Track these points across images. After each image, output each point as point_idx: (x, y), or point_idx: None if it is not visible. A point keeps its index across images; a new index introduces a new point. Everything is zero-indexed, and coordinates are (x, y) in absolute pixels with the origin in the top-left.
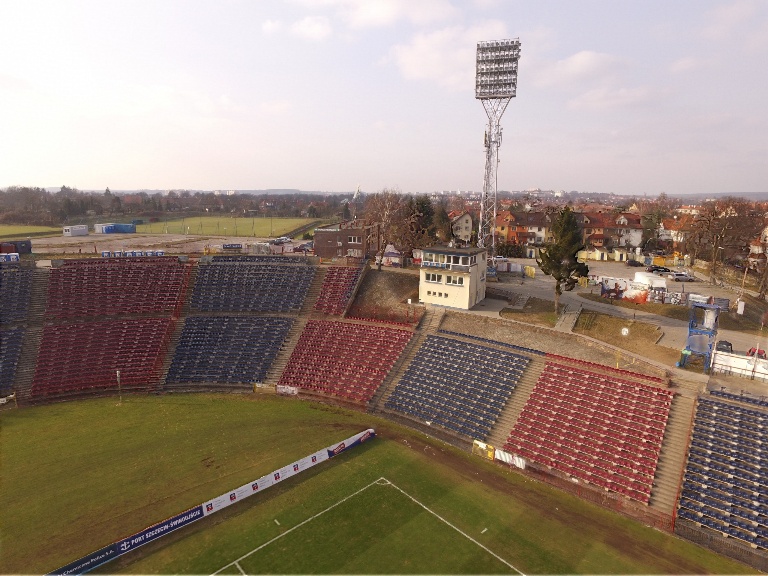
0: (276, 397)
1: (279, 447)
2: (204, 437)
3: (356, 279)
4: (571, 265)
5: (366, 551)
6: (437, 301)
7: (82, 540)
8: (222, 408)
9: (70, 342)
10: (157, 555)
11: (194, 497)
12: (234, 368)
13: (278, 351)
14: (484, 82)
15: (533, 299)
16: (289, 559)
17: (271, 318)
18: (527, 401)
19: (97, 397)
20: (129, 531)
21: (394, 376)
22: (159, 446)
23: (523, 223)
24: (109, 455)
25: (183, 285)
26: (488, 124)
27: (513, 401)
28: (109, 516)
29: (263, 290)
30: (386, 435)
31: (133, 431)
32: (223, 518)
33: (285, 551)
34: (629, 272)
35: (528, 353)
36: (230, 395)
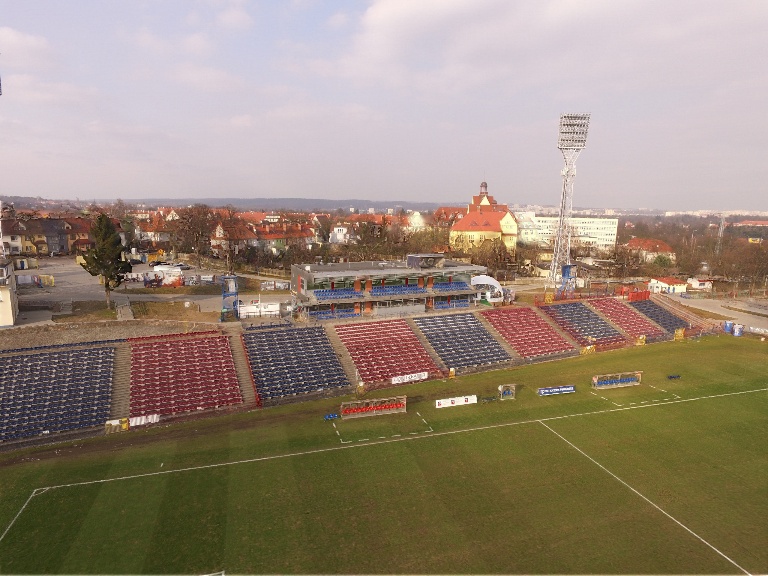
0: None
1: None
2: None
3: None
4: (117, 264)
5: (81, 529)
6: None
7: None
8: None
9: None
10: None
11: None
12: None
13: None
14: None
15: (77, 302)
16: None
17: None
18: (131, 379)
19: None
20: None
21: None
22: None
23: None
24: None
25: None
26: None
27: (118, 384)
28: None
29: None
30: None
31: None
32: None
33: None
34: (137, 269)
35: (109, 344)
36: None
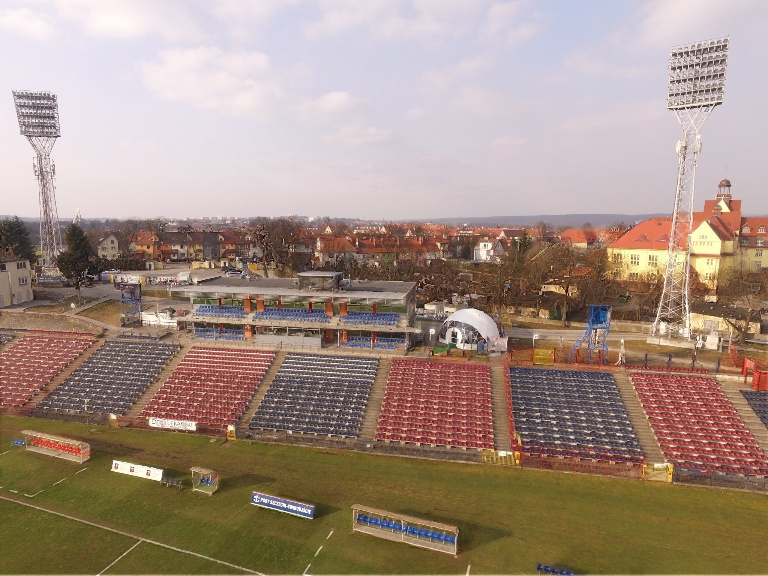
0: None
1: None
2: None
3: None
4: None
5: None
6: None
7: None
8: None
9: None
10: None
11: None
12: None
13: None
14: (27, 123)
15: (75, 297)
16: None
17: None
18: None
19: None
20: None
21: None
22: None
23: (166, 242)
24: None
25: None
26: (36, 157)
27: None
28: None
29: None
30: None
31: None
32: None
33: None
34: None
35: (17, 332)
36: None
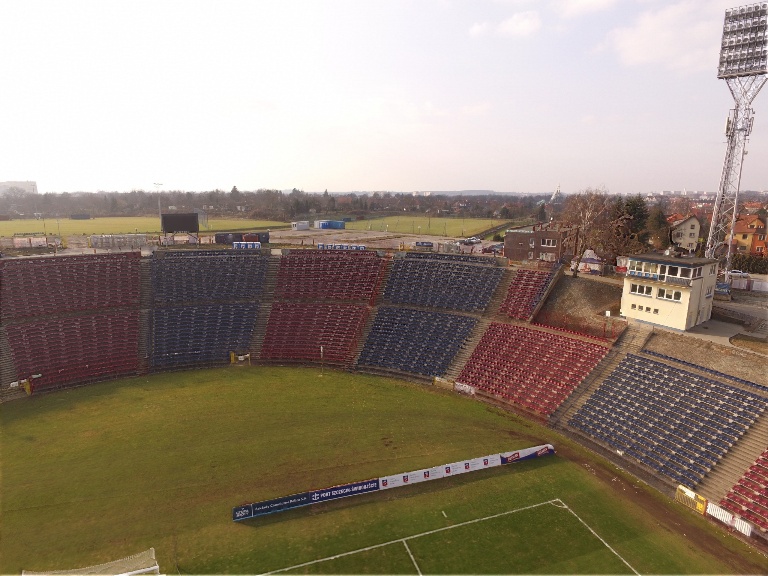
0: (453, 393)
1: (452, 442)
2: (385, 418)
3: (547, 284)
4: None
5: (533, 571)
6: (643, 317)
7: (285, 482)
8: (403, 395)
9: (289, 318)
10: (339, 512)
11: (373, 470)
12: (417, 359)
13: (459, 349)
14: (732, 57)
15: None
16: (453, 553)
17: (455, 316)
18: (762, 453)
19: (305, 367)
20: (319, 485)
21: (582, 393)
22: (348, 418)
23: None
24: (310, 417)
25: (379, 277)
26: (734, 108)
27: (740, 450)
28: (306, 468)
29: (450, 288)
30: (567, 455)
31: (329, 401)
32: (396, 496)
33: (450, 544)
34: None
35: None
36: (411, 384)
